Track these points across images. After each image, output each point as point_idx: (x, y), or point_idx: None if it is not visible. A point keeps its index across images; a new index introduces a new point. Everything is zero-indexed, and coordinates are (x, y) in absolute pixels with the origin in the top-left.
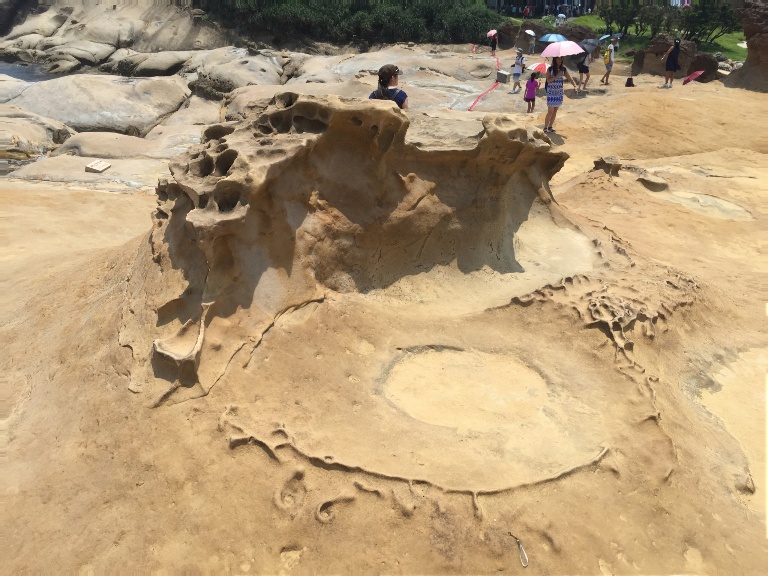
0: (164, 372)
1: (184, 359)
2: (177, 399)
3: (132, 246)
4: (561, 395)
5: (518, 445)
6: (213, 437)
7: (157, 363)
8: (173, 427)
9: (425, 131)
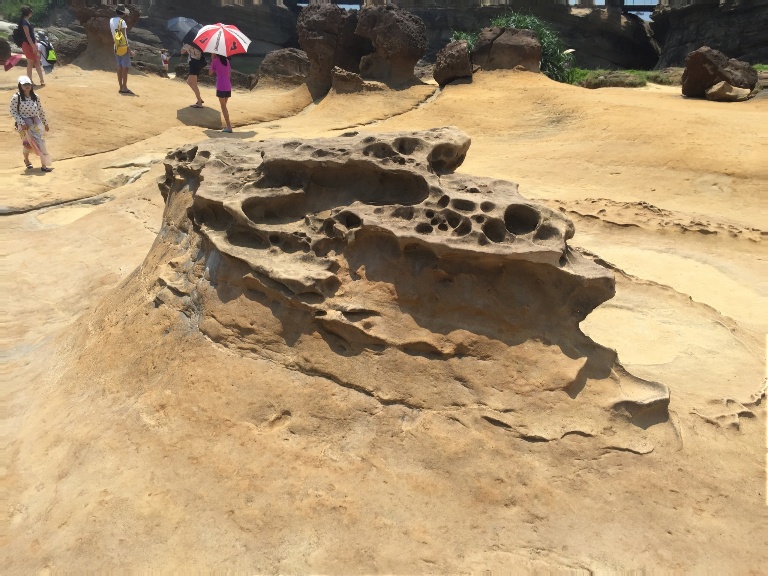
0: (647, 420)
1: (669, 394)
2: (679, 430)
3: (275, 381)
4: (647, 311)
5: (703, 344)
6: (721, 434)
7: (636, 418)
8: (705, 448)
9: None
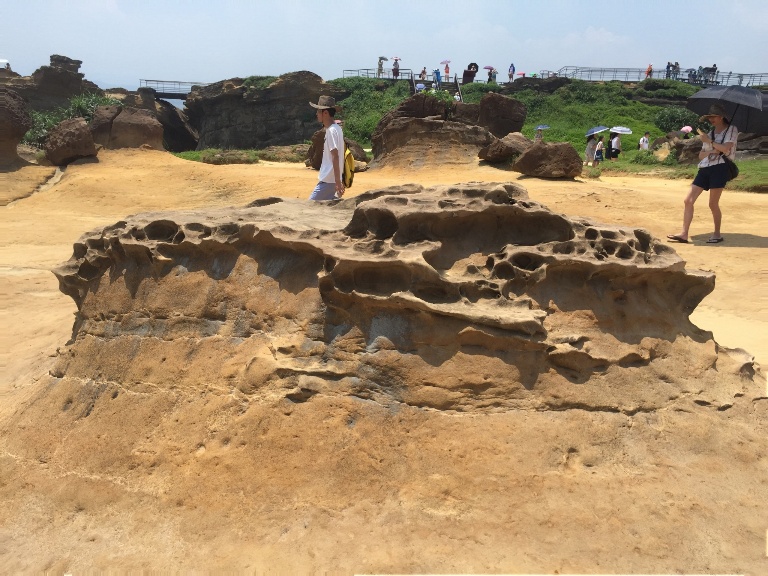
0: (750, 376)
1: None
2: None
3: (543, 425)
4: None
5: None
6: None
7: None
8: None
9: (340, 216)
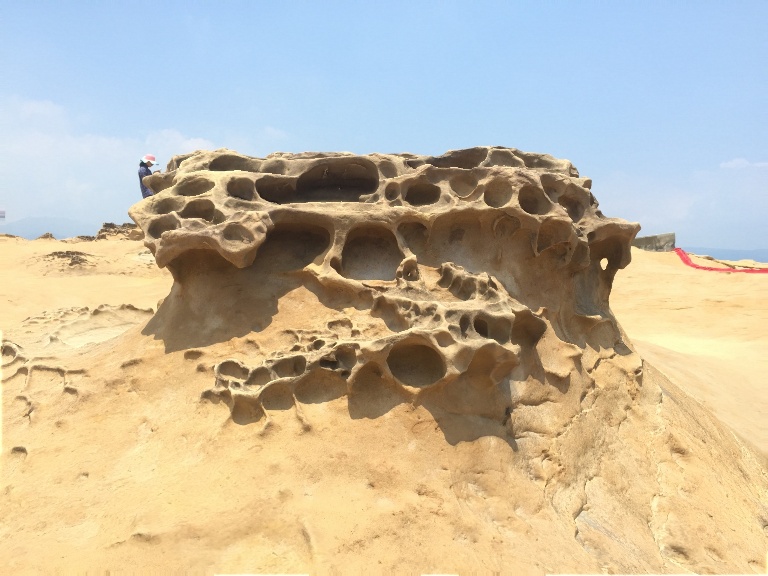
0: None
1: None
2: None
3: None
4: None
5: None
6: None
7: None
8: None
9: None
